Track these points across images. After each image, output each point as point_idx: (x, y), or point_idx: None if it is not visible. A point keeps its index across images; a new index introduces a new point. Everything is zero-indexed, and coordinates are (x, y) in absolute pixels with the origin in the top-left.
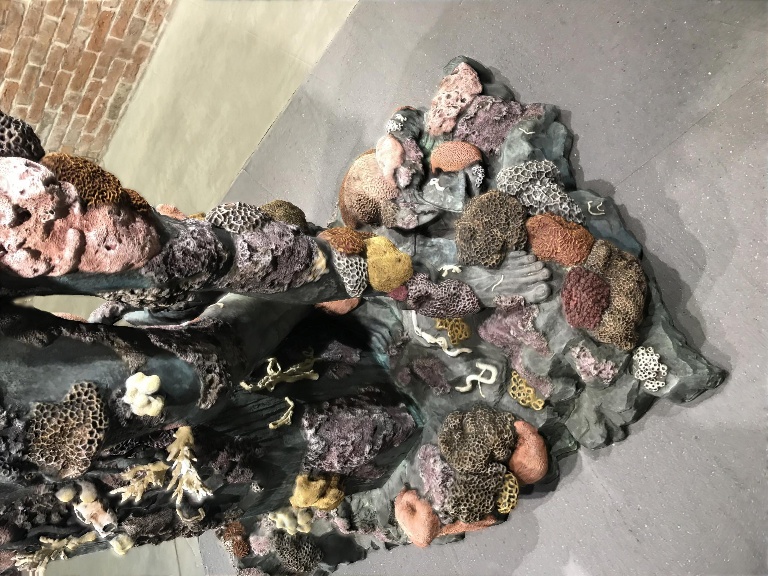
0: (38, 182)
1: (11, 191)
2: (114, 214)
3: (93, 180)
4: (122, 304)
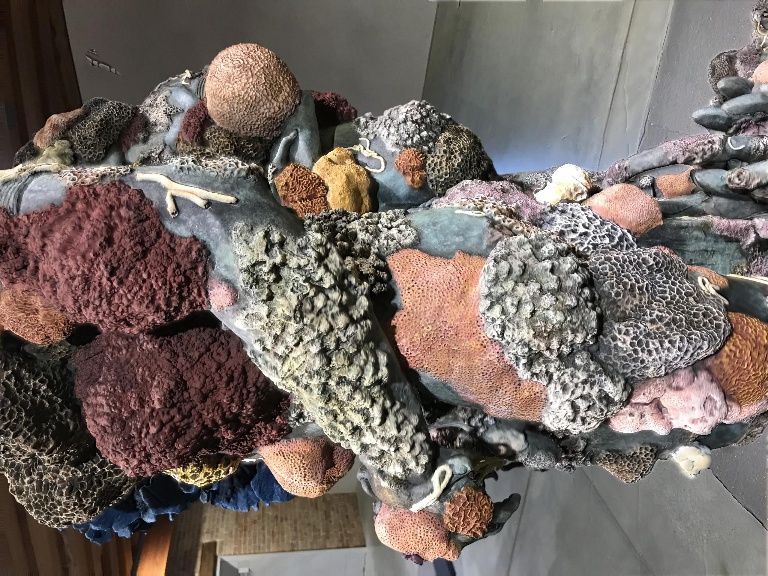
0: (708, 430)
1: (677, 422)
2: (763, 403)
3: (763, 382)
4: (701, 156)
